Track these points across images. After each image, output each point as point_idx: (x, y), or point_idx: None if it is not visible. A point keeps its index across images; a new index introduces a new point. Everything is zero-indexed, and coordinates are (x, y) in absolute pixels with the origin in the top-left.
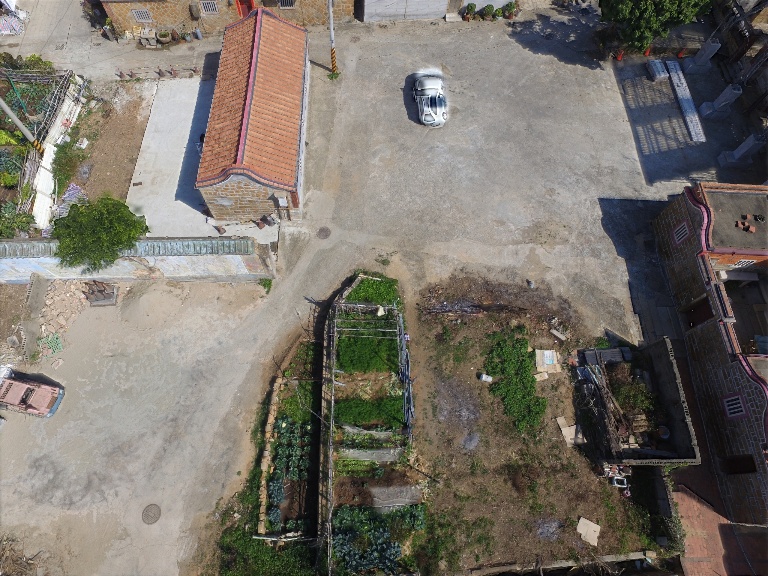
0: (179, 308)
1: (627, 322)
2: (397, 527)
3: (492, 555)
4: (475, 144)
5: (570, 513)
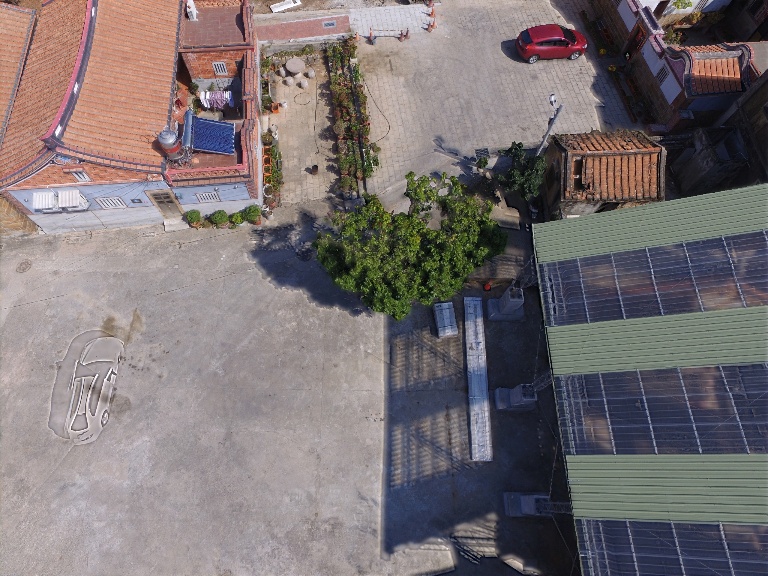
0: None
1: None
2: None
3: None
4: (133, 477)
5: None
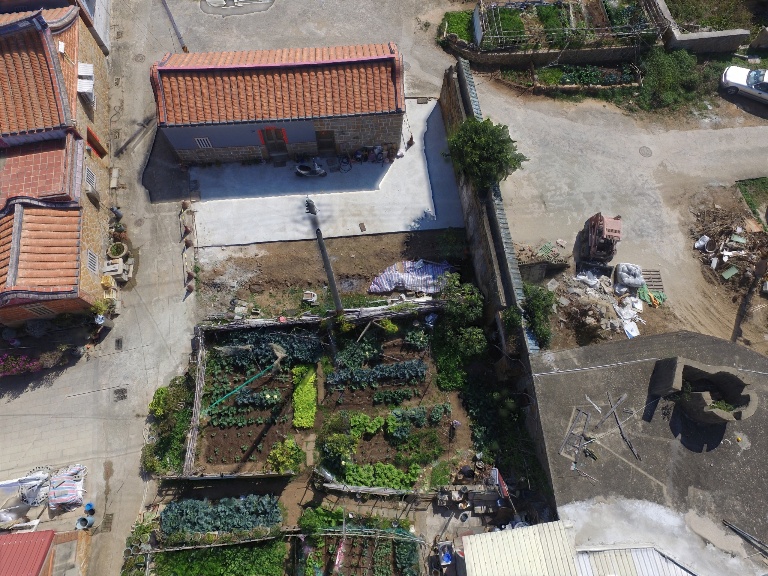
0: None
1: None
2: None
3: None
4: None
5: None
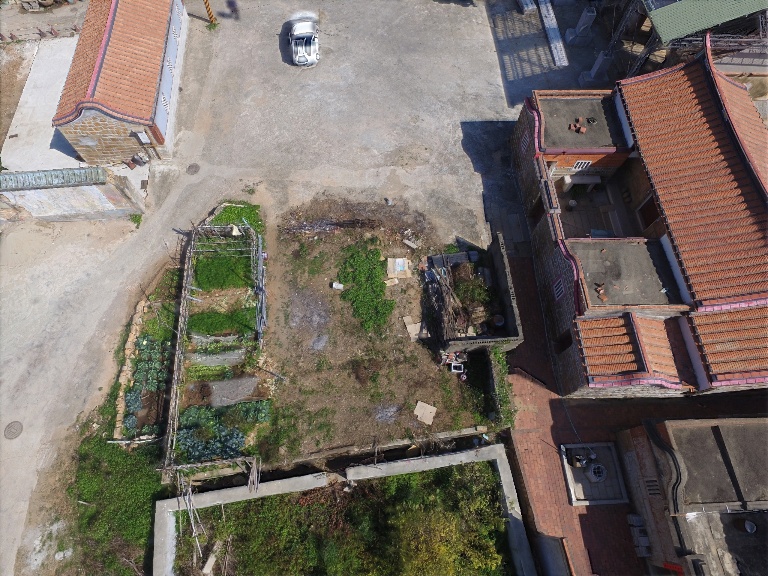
0: (49, 246)
1: (478, 230)
2: (242, 420)
3: (332, 440)
4: (345, 80)
5: (409, 398)
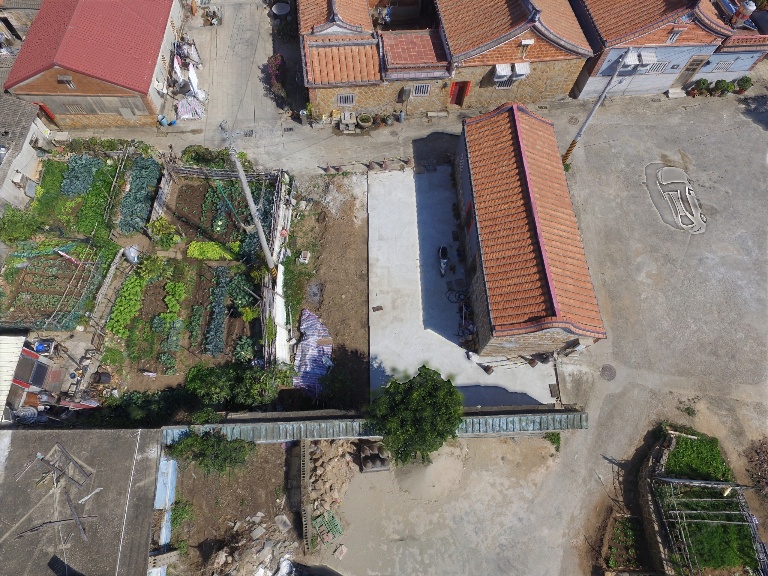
0: (462, 472)
1: None
2: None
3: None
4: (749, 254)
5: None
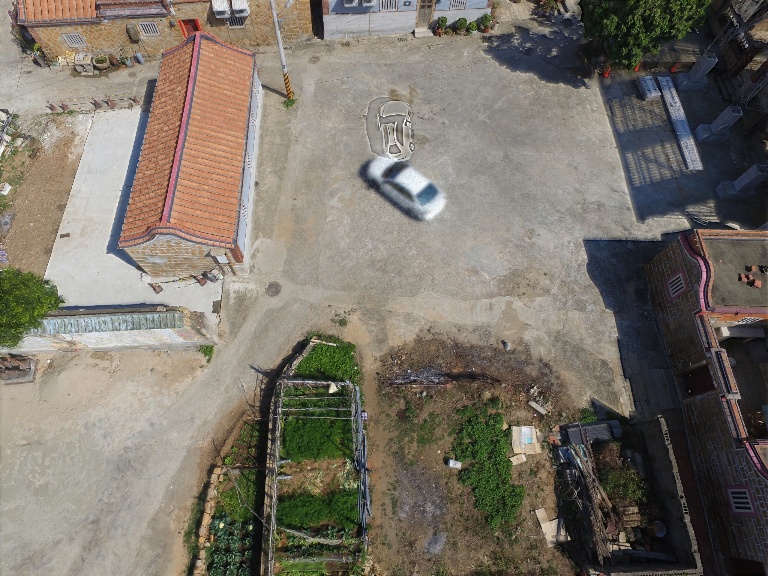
0: (106, 383)
1: (616, 389)
2: None
3: None
4: (445, 179)
5: None
